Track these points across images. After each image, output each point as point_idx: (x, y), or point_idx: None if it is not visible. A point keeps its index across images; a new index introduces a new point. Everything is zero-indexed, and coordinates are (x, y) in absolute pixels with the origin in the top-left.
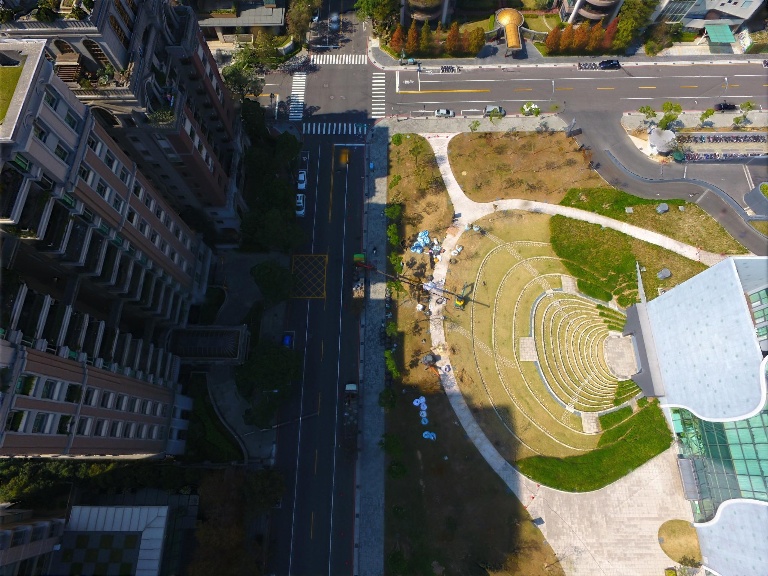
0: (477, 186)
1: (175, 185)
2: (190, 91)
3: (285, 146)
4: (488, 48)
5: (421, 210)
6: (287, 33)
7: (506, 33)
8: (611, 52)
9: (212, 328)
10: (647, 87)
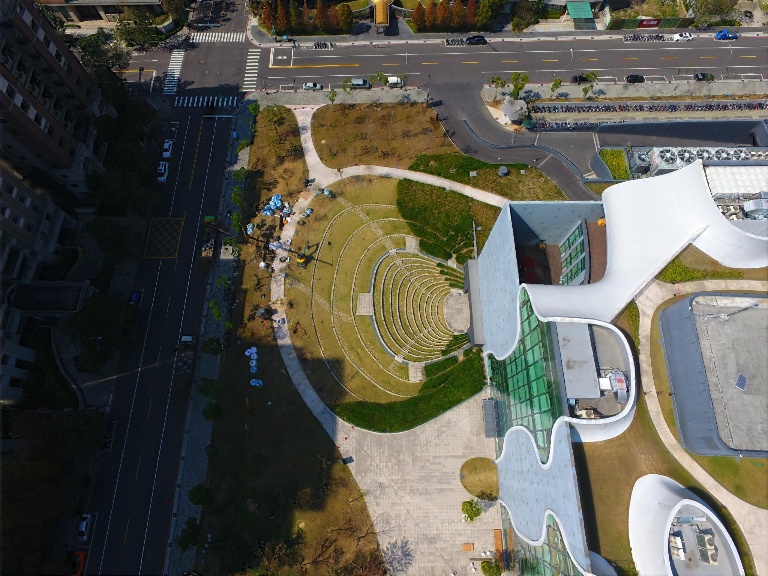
0: (333, 153)
1: (9, 144)
2: (23, 55)
3: (133, 112)
4: (362, 26)
5: (277, 176)
6: (166, 12)
7: (375, 10)
8: (478, 29)
9: (56, 284)
10: (510, 61)
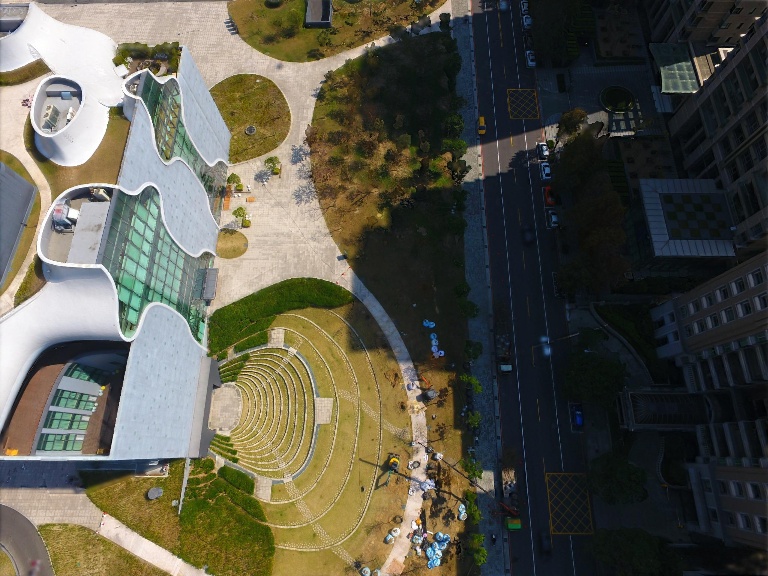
0: None
1: None
2: None
3: None
4: None
5: None
6: None
7: None
8: None
9: (667, 427)
10: None
